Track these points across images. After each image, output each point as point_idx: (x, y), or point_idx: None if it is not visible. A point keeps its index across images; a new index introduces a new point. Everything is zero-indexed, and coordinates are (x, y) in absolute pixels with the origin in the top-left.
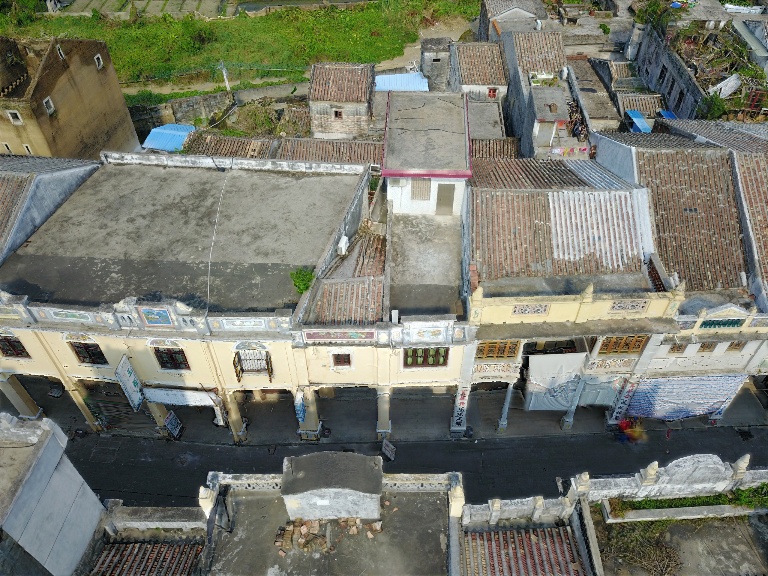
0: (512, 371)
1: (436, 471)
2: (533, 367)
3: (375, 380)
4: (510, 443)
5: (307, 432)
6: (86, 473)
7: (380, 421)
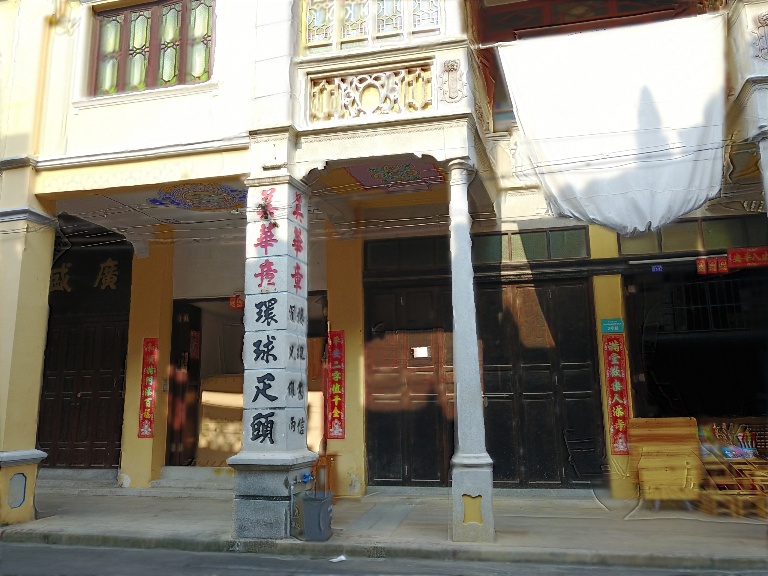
0: (442, 96)
1: None
2: (529, 104)
3: (2, 156)
4: (509, 568)
5: None
6: None
7: None
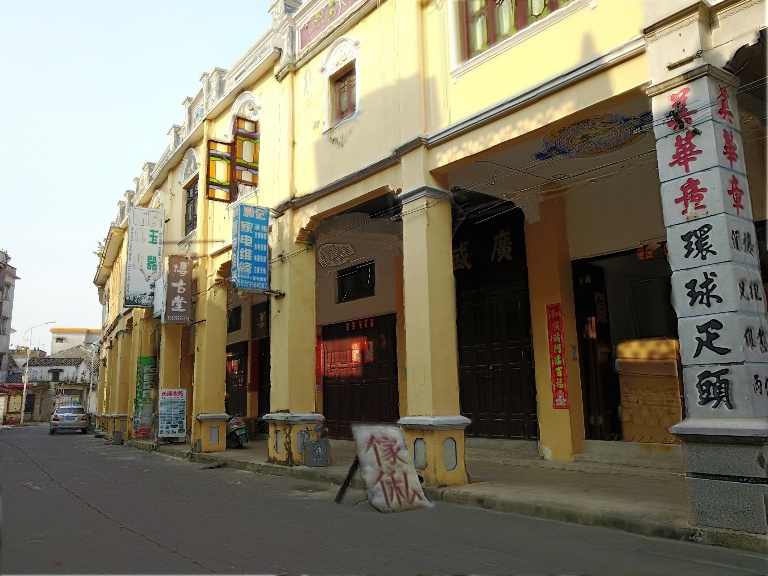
0: None
1: (479, 553)
2: None
3: (399, 144)
4: None
5: (275, 415)
6: (53, 449)
7: (410, 359)
